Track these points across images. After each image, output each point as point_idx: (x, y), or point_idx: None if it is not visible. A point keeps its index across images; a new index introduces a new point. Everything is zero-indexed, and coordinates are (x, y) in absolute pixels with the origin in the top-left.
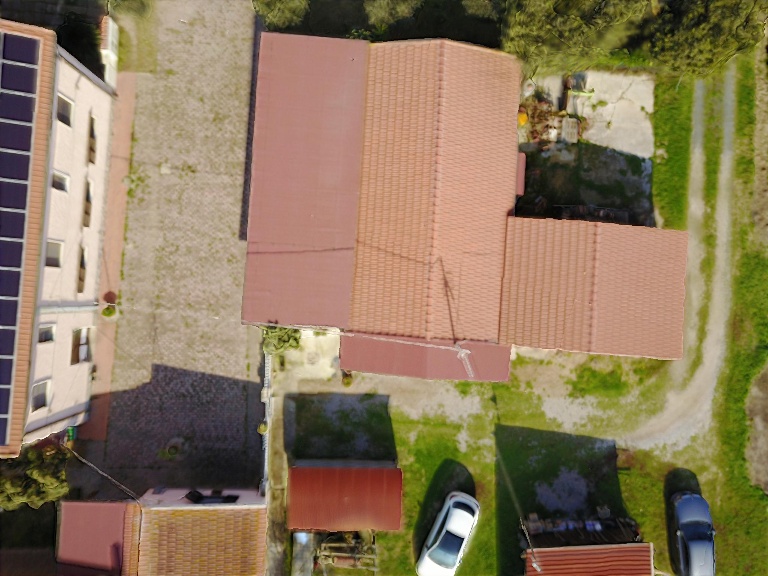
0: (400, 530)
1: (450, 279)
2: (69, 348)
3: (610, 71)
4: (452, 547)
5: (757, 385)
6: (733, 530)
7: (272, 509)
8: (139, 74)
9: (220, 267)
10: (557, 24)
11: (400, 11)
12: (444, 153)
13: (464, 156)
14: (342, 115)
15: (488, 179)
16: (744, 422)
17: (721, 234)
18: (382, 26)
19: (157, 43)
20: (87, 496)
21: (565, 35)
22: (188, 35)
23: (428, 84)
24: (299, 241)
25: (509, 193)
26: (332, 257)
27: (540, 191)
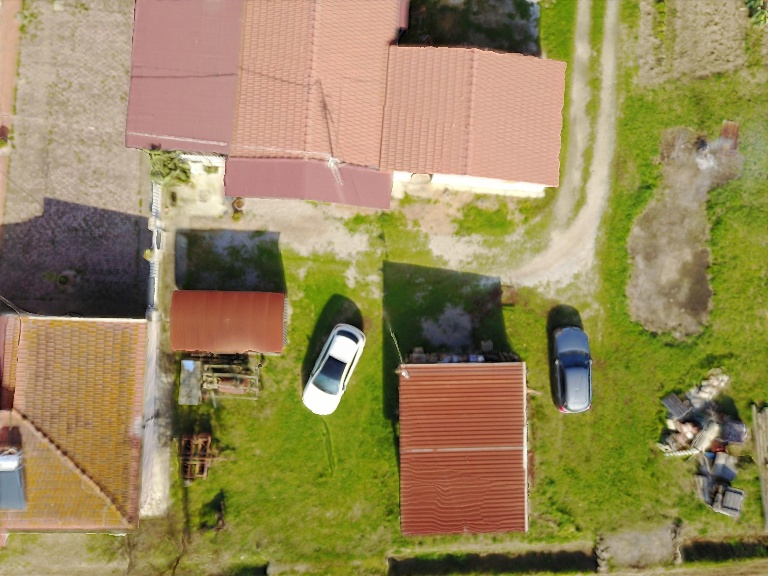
0: (289, 363)
1: (330, 103)
2: None
3: None
4: (336, 373)
5: (639, 225)
6: (613, 364)
7: (163, 341)
8: None
9: (113, 104)
10: None
11: None
12: None
13: None
14: None
15: (370, 8)
16: (626, 260)
17: (607, 78)
18: None
19: None
20: None
21: None
22: None
23: None
24: (183, 67)
25: (392, 24)
26: (216, 83)
27: (430, 33)
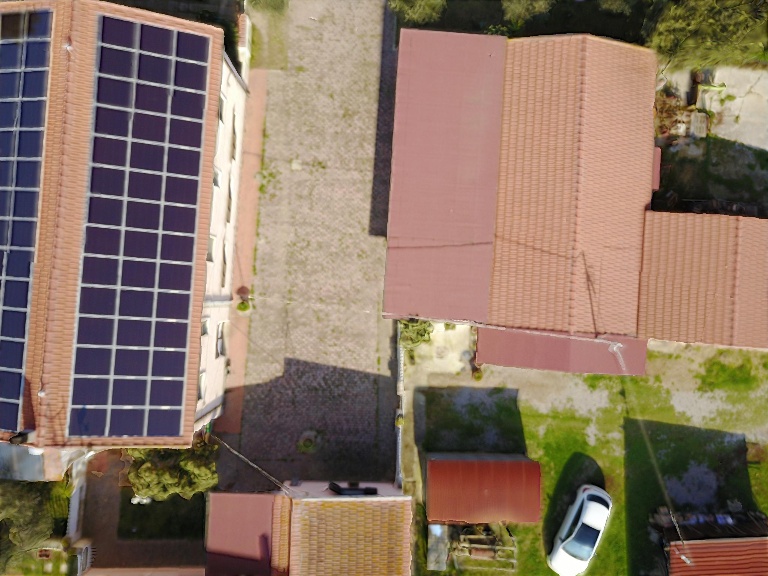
0: (530, 522)
1: (591, 273)
2: (214, 342)
3: (739, 65)
4: (587, 539)
5: None
6: None
7: None
8: (270, 71)
9: (350, 262)
10: (721, 18)
11: (538, 7)
12: (585, 148)
13: (604, 151)
14: (480, 111)
15: (626, 174)
16: None
17: None
18: (518, 22)
19: (288, 40)
20: (223, 488)
21: (729, 29)
22: (318, 32)
23: (569, 79)
24: (438, 236)
25: (646, 187)
26: (471, 252)
27: (668, 185)
